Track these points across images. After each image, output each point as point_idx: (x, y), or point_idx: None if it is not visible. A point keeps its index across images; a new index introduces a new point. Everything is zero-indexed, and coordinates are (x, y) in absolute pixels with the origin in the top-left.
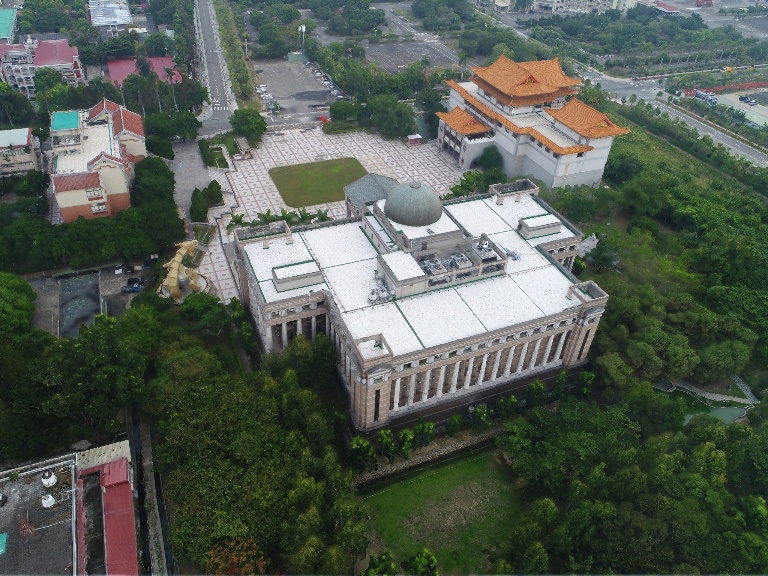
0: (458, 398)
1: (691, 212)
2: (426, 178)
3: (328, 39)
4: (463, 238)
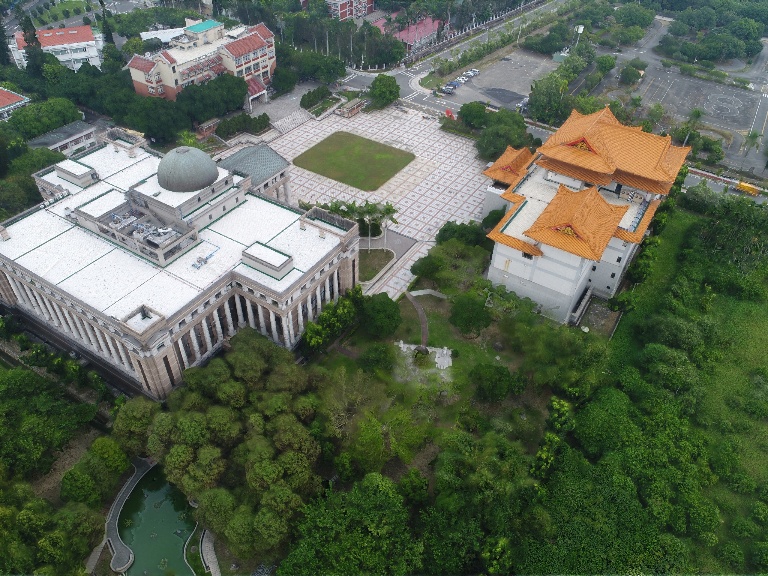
0: (59, 333)
1: (557, 408)
2: (432, 204)
3: (642, 55)
4: (178, 218)
